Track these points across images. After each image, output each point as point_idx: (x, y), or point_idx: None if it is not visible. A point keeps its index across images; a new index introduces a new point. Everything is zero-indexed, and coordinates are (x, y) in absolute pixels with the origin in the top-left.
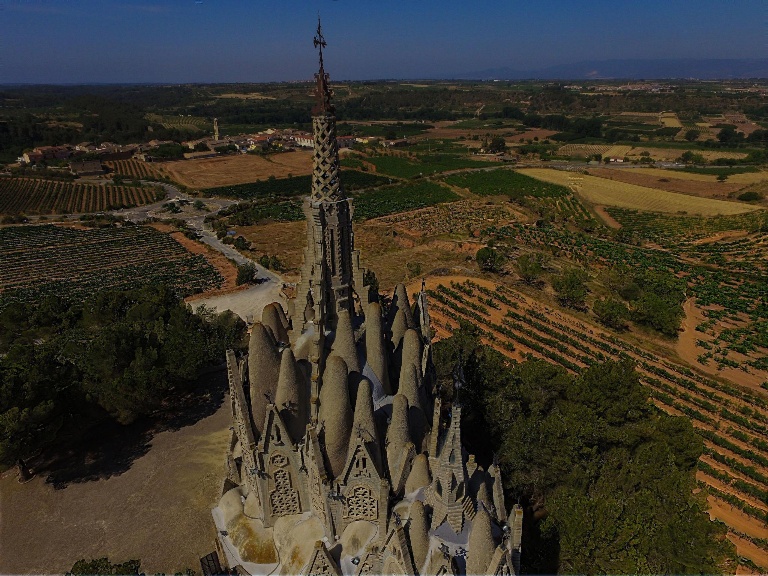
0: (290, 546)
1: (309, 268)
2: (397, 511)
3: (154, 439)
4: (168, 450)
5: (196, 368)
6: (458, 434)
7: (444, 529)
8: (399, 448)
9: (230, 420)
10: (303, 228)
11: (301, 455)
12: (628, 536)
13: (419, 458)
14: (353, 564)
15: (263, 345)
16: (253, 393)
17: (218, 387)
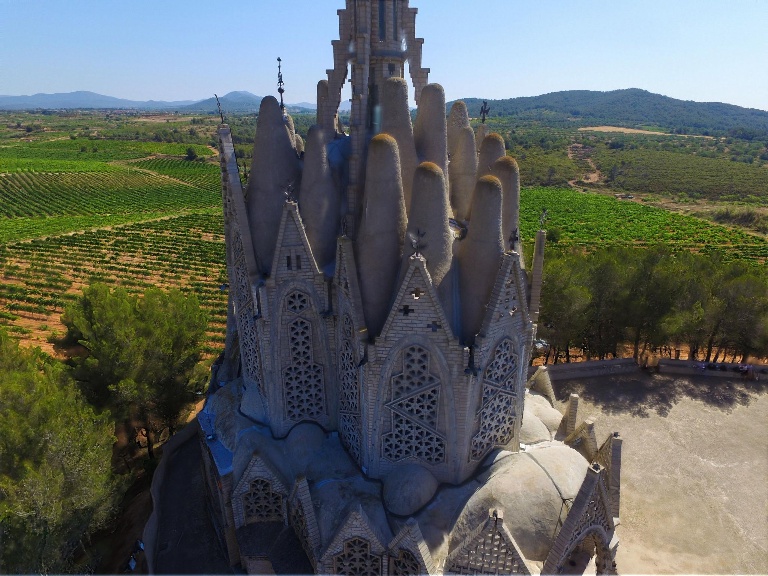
0: None
1: None
2: None
3: None
4: None
5: None
6: None
7: None
8: None
9: None
10: None
11: None
12: None
13: None
14: None
15: None
16: None
17: None
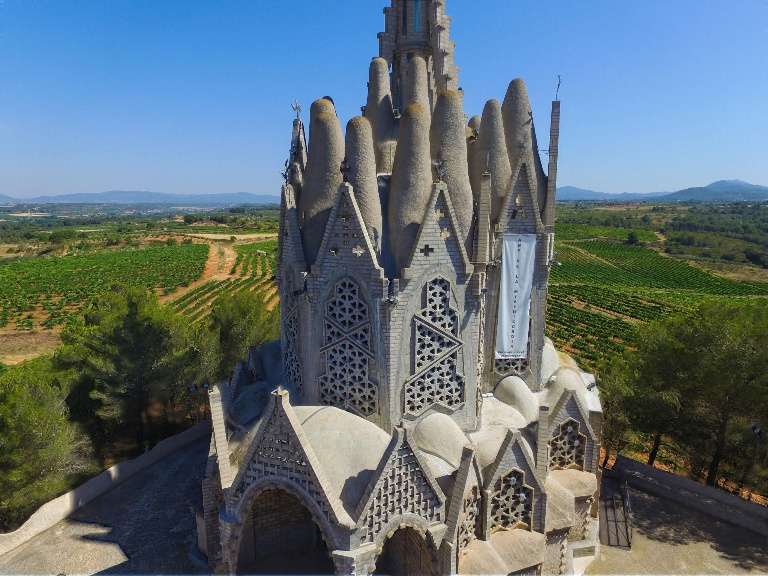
0: None
1: None
2: None
3: None
4: None
5: None
6: None
7: None
8: None
9: None
10: None
11: None
12: None
13: None
14: None
15: None
16: None
17: None
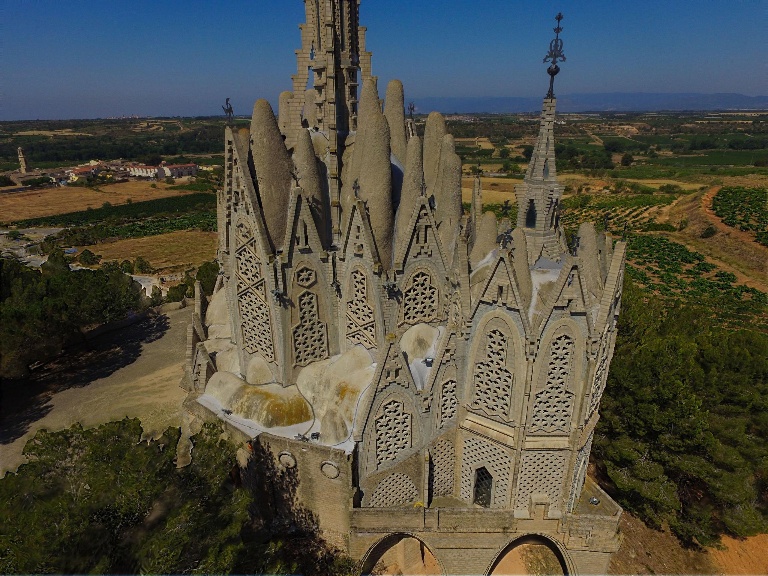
0: (329, 389)
1: (308, 49)
2: (476, 274)
3: (54, 399)
4: (81, 404)
5: (104, 303)
6: (552, 137)
7: (543, 263)
8: (454, 223)
9: (159, 363)
10: (162, 241)
11: (332, 265)
12: (646, 322)
13: (488, 213)
14: (424, 368)
15: (271, 126)
16: (263, 191)
17: (129, 340)
